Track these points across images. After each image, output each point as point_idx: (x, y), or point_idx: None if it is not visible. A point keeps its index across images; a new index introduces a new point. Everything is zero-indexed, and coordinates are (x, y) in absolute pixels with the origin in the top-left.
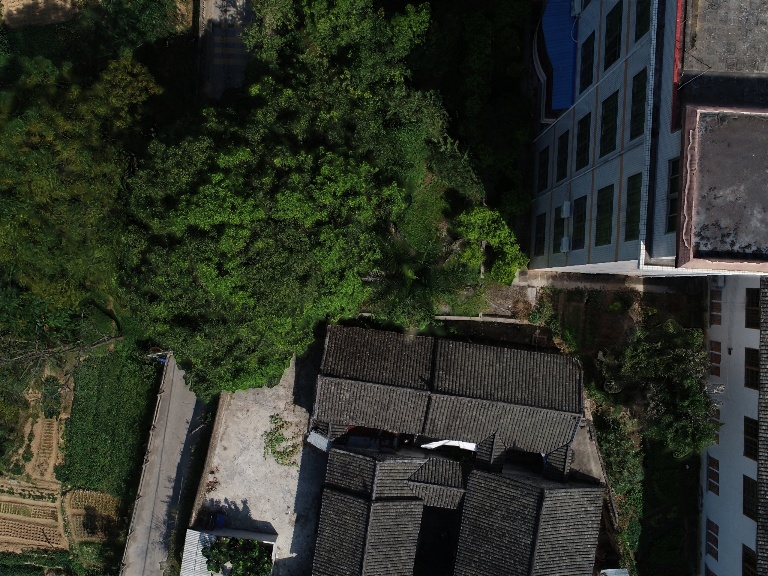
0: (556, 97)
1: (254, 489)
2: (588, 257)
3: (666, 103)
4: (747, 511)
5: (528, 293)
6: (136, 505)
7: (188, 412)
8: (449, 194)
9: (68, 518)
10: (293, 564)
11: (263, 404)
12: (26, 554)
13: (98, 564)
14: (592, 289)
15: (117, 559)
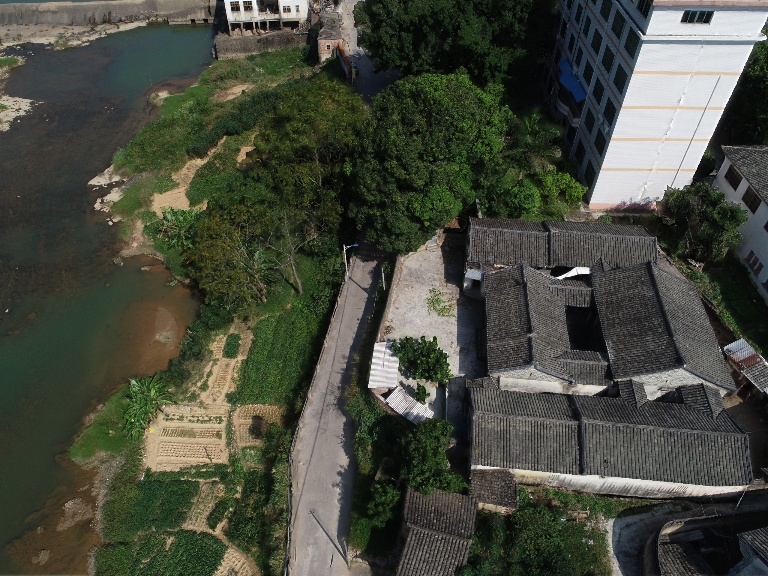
0: (577, 98)
1: (423, 332)
2: (620, 106)
3: (627, 3)
4: None
5: (593, 216)
6: (314, 377)
7: (359, 313)
8: (527, 176)
9: (235, 428)
10: None
11: (423, 283)
12: (184, 471)
13: (259, 467)
14: (634, 216)
15: None
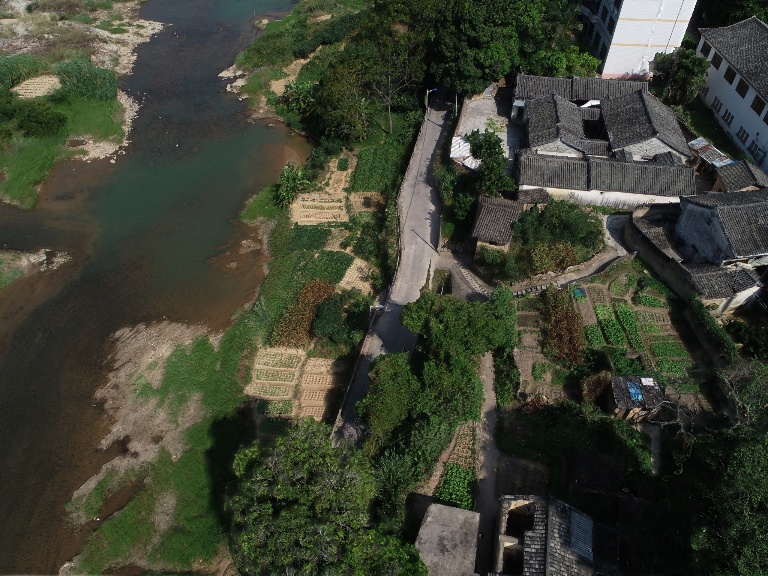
0: None
1: None
2: None
3: None
4: (744, 96)
5: None
6: (408, 167)
7: (436, 137)
8: None
9: (352, 203)
10: (511, 162)
11: None
12: None
13: (371, 221)
14: None
15: (384, 218)
